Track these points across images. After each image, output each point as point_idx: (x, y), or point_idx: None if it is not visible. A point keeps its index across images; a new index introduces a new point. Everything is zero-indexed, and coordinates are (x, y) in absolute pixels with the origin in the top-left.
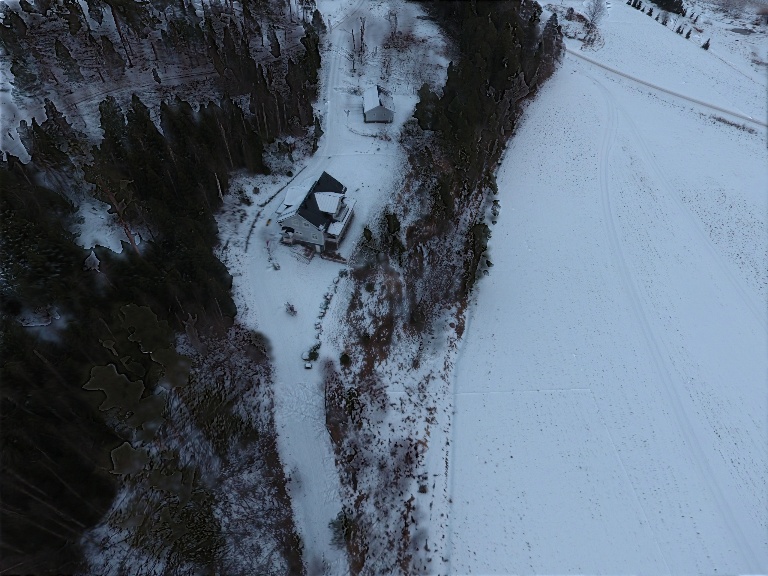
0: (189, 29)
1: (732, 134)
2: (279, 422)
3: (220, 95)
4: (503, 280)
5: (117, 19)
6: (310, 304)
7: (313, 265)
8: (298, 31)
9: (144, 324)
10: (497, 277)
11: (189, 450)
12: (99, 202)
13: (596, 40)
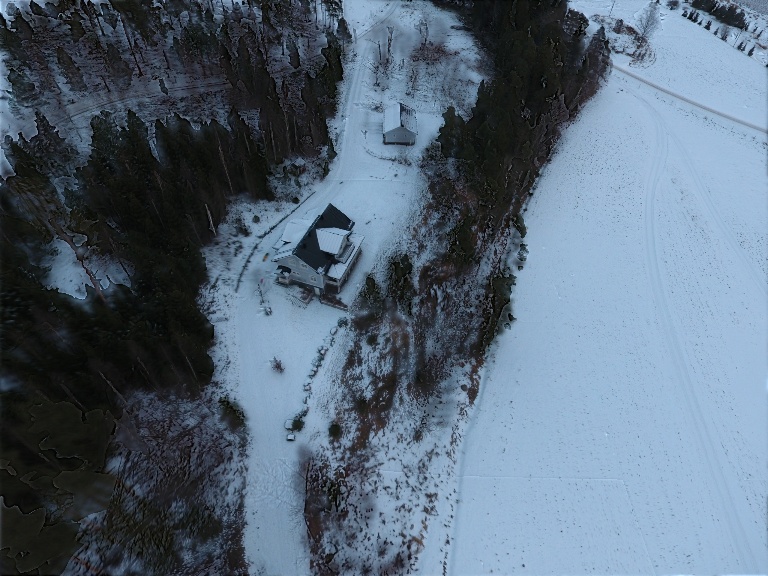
0: (202, 37)
1: None
2: (250, 507)
3: (230, 109)
4: (527, 333)
5: (126, 25)
6: (301, 359)
7: (310, 310)
8: (323, 39)
9: (61, 426)
10: (520, 329)
11: (137, 545)
12: None
13: (647, 55)
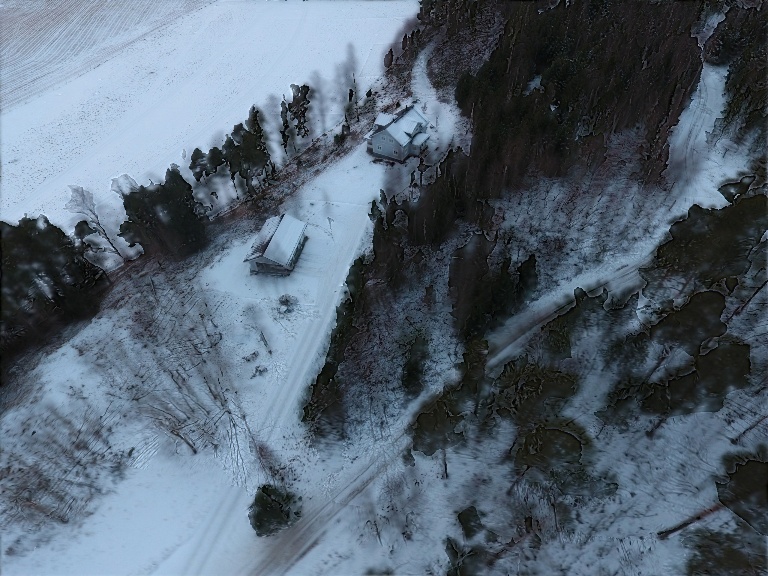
0: None
1: None
2: None
3: None
4: None
5: None
6: None
7: None
8: None
9: None
10: None
11: None
12: None
13: None
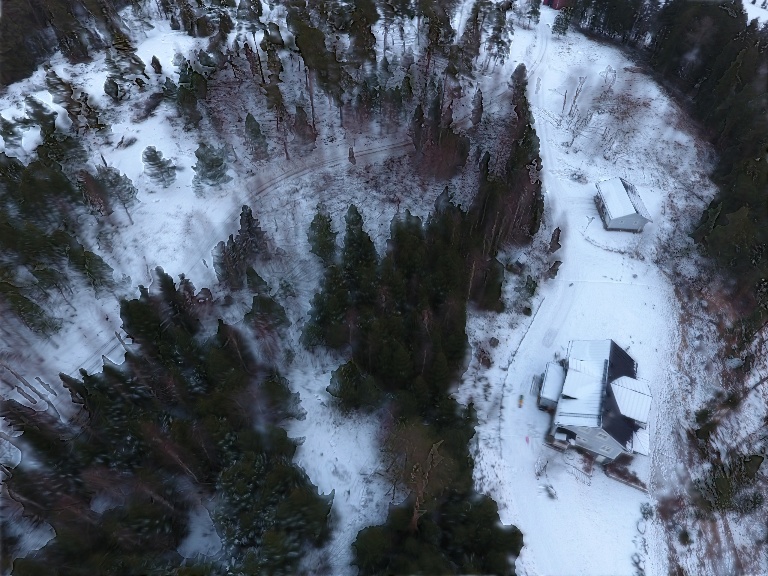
0: (390, 94)
1: None
2: None
3: (422, 181)
4: None
5: (313, 83)
6: None
7: (597, 488)
8: (486, 83)
9: None
10: None
11: None
12: (311, 368)
13: None
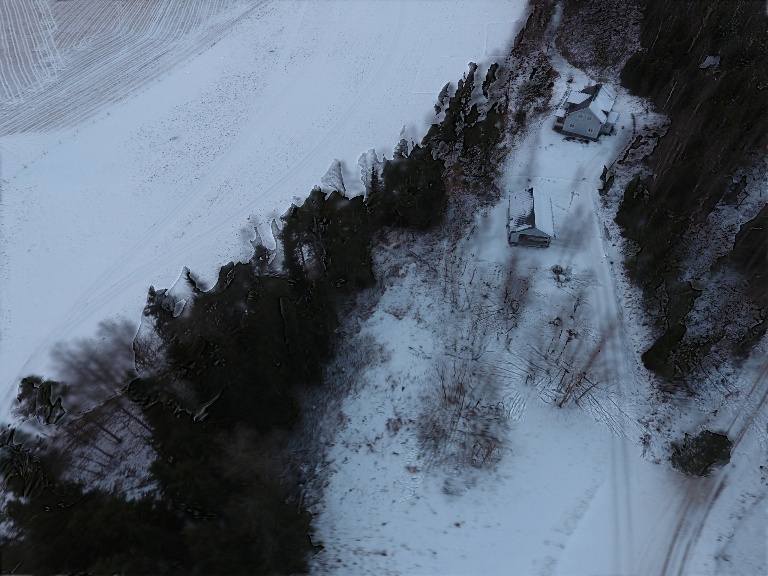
0: None
1: (3, 235)
2: None
3: None
4: None
5: None
6: None
7: None
8: None
9: None
10: None
11: None
12: None
13: None
